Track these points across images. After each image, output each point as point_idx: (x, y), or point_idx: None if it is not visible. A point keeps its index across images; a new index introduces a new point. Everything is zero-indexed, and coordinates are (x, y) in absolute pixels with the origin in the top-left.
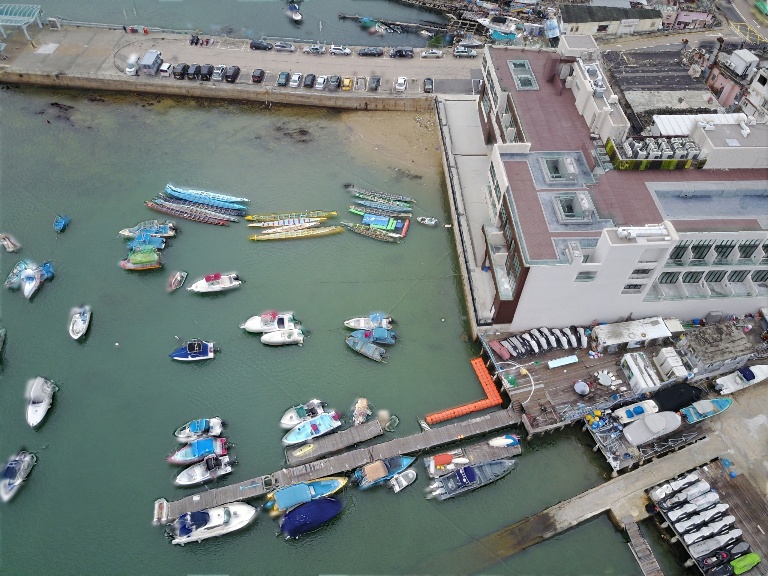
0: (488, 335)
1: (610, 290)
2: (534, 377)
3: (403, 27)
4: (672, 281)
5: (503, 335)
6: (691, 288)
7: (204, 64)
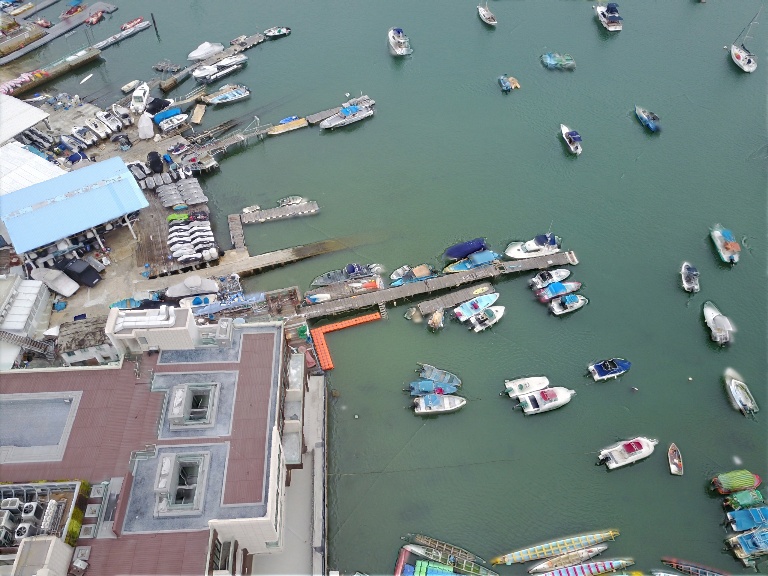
0: None
1: None
2: None
3: None
4: None
5: None
6: None
7: None
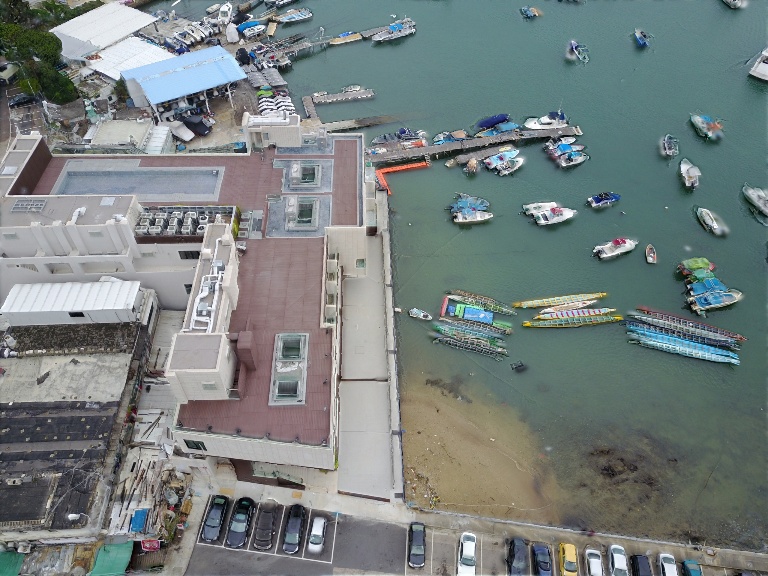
0: None
1: None
2: None
3: None
4: None
5: None
6: None
7: None
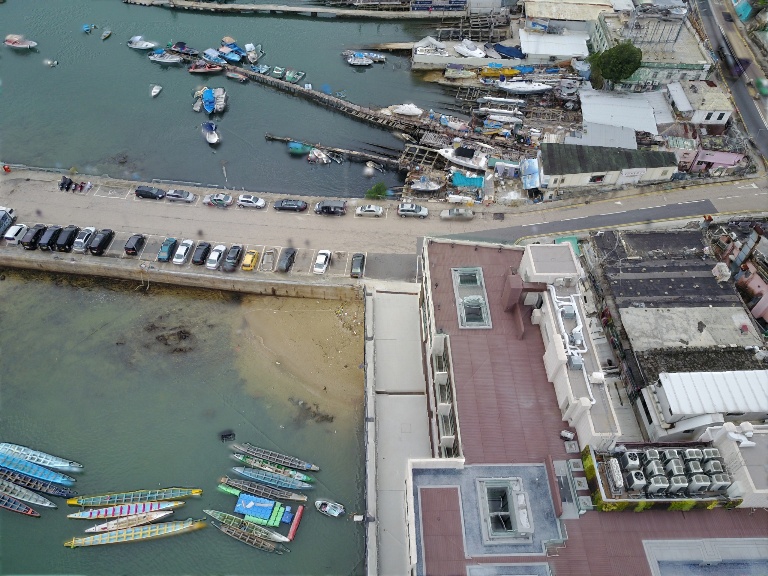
0: None
1: None
2: None
3: (344, 155)
4: None
5: None
6: None
7: None
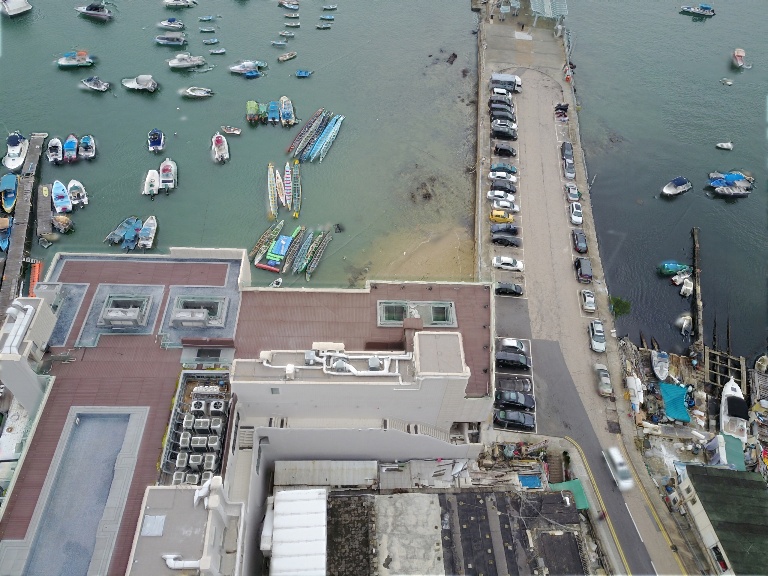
0: None
1: None
2: None
3: (694, 296)
4: None
5: None
6: None
7: None
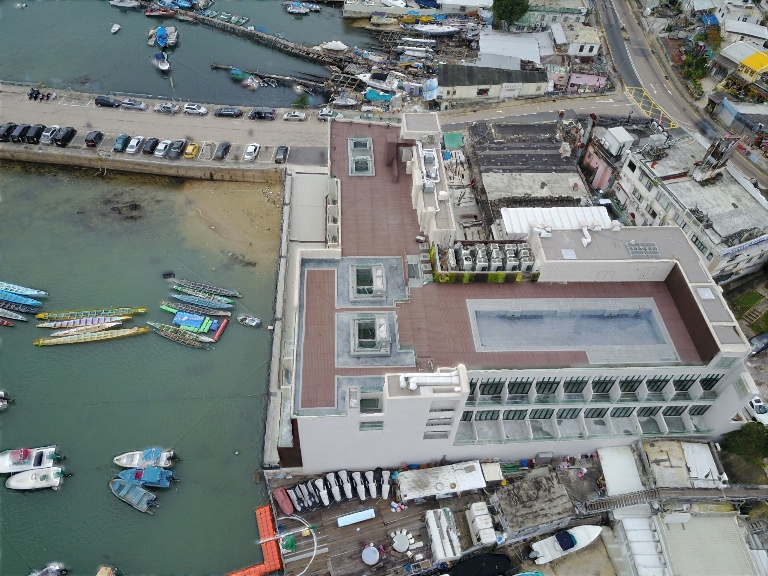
0: (277, 479)
1: (408, 437)
2: (319, 538)
3: (279, 80)
4: (493, 418)
5: (295, 479)
6: (515, 426)
7: (35, 124)
